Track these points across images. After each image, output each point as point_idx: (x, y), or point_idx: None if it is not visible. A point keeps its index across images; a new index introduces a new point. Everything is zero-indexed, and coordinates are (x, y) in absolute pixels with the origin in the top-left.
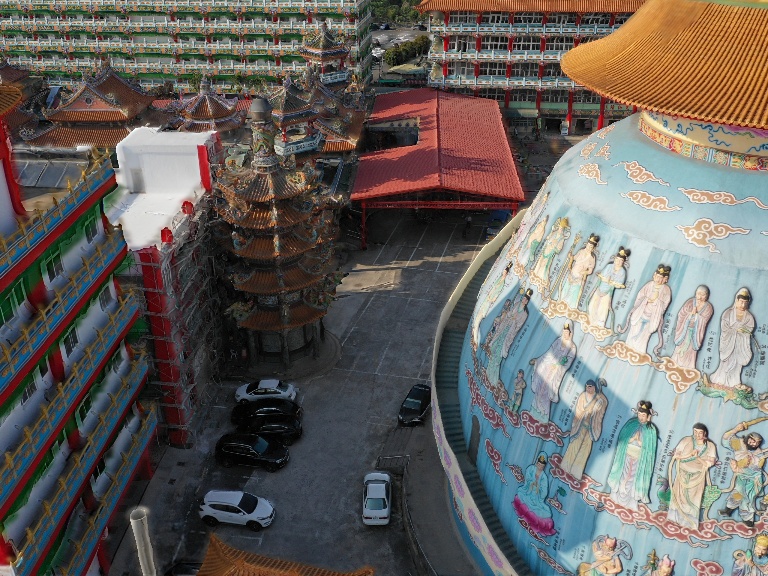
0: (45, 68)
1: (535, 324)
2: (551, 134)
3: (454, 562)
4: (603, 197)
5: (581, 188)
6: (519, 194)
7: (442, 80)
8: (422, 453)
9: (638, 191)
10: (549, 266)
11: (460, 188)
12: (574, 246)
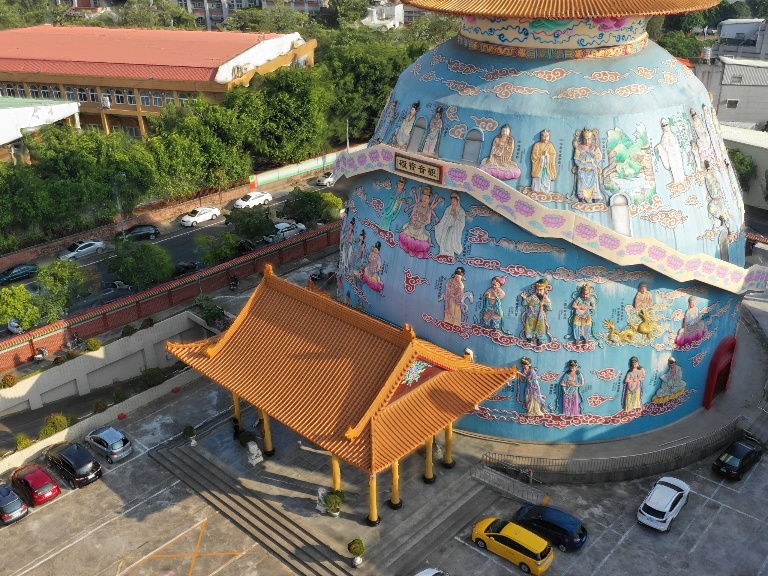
0: None
1: None
2: None
3: (738, 338)
4: None
5: None
6: None
7: None
8: (745, 405)
9: None
10: None
11: None
12: None
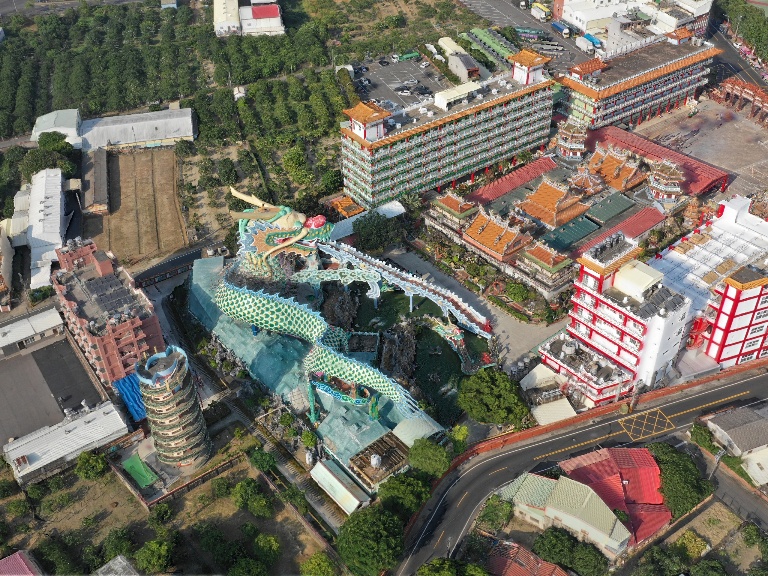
0: (414, 186)
1: None
2: None
3: None
4: None
5: None
6: (724, 172)
7: None
8: None
9: None
10: None
11: (717, 178)
12: None
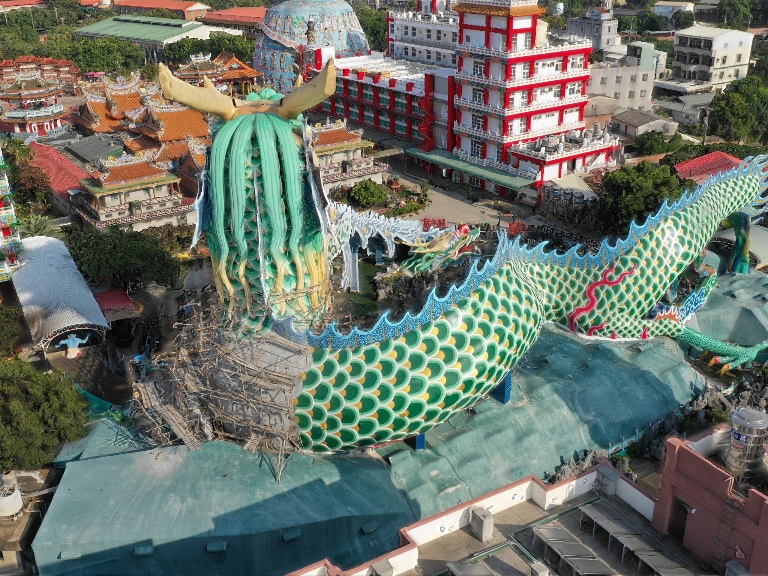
0: None
1: None
2: None
3: None
4: None
5: None
6: None
7: None
8: None
9: (342, 4)
10: None
11: None
12: None
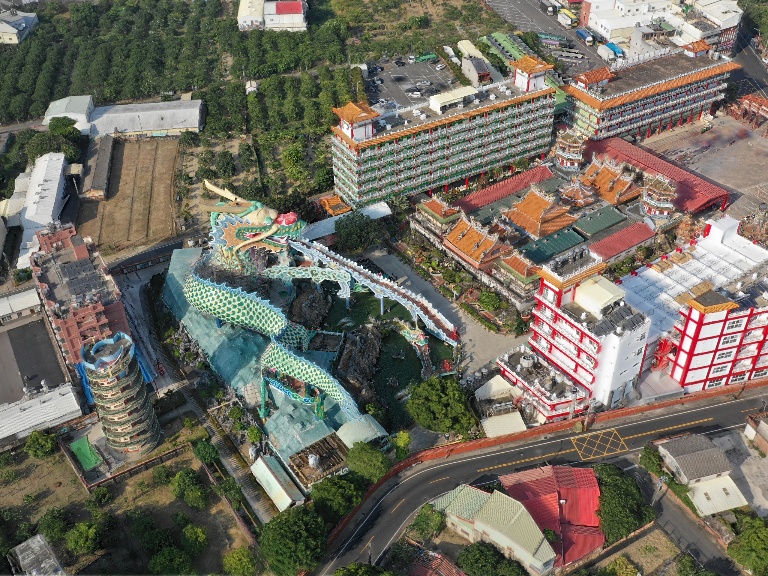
0: (403, 188)
1: None
2: (633, 144)
3: None
4: None
5: None
6: (725, 191)
7: (601, 136)
8: None
9: None
10: None
11: (715, 197)
12: None
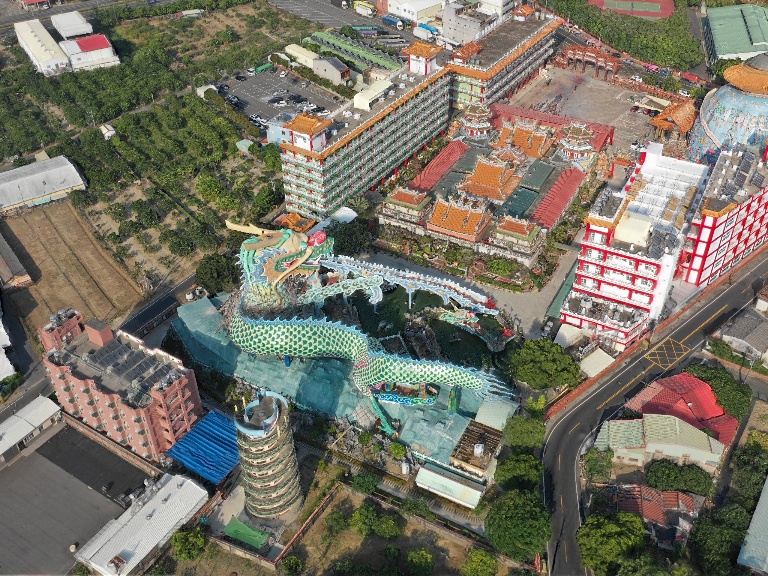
0: None
1: (766, 133)
2: None
3: None
4: (766, 109)
5: (761, 109)
6: None
7: None
8: None
9: None
10: (763, 123)
11: None
12: (767, 118)
